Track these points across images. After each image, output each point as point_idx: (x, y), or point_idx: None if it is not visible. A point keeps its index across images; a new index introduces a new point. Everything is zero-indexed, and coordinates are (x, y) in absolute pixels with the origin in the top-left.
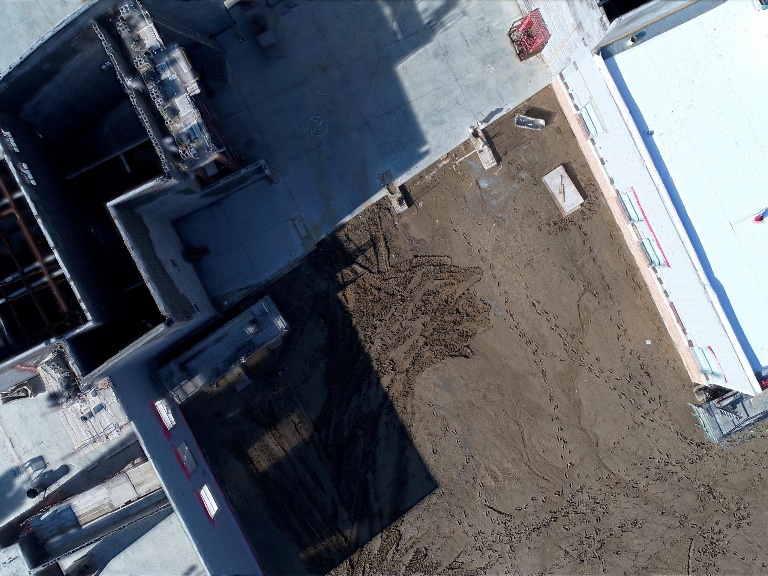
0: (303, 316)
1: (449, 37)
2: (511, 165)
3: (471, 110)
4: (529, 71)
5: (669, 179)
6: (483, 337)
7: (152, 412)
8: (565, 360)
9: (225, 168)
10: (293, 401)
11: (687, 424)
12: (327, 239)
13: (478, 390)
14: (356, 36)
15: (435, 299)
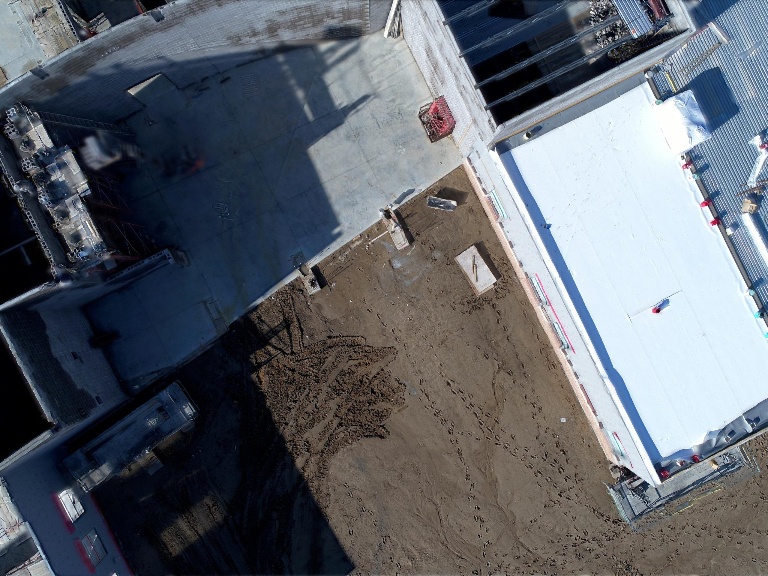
0: (216, 398)
1: (360, 119)
2: (424, 245)
3: (383, 191)
4: (440, 152)
5: (567, 272)
6: (398, 417)
7: (55, 505)
8: (481, 439)
9: (125, 261)
10: (207, 484)
11: (603, 501)
12: (240, 321)
13: (394, 470)
14: (267, 118)
15: (350, 379)
